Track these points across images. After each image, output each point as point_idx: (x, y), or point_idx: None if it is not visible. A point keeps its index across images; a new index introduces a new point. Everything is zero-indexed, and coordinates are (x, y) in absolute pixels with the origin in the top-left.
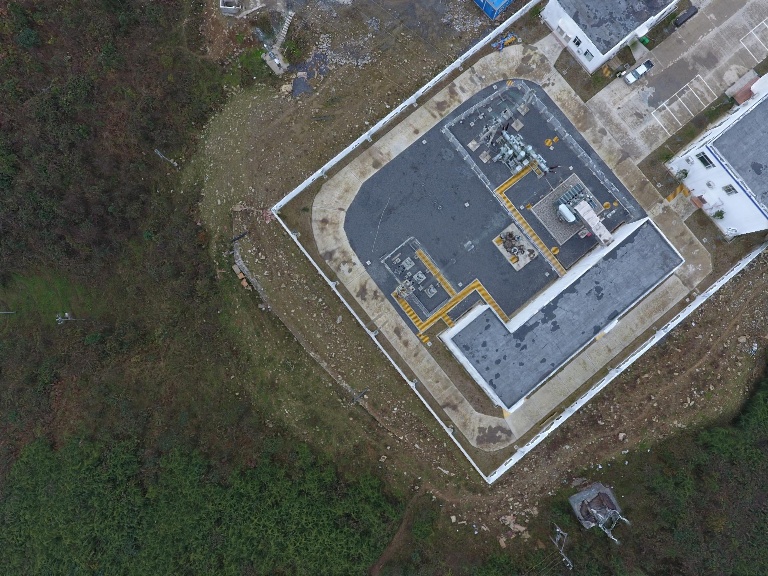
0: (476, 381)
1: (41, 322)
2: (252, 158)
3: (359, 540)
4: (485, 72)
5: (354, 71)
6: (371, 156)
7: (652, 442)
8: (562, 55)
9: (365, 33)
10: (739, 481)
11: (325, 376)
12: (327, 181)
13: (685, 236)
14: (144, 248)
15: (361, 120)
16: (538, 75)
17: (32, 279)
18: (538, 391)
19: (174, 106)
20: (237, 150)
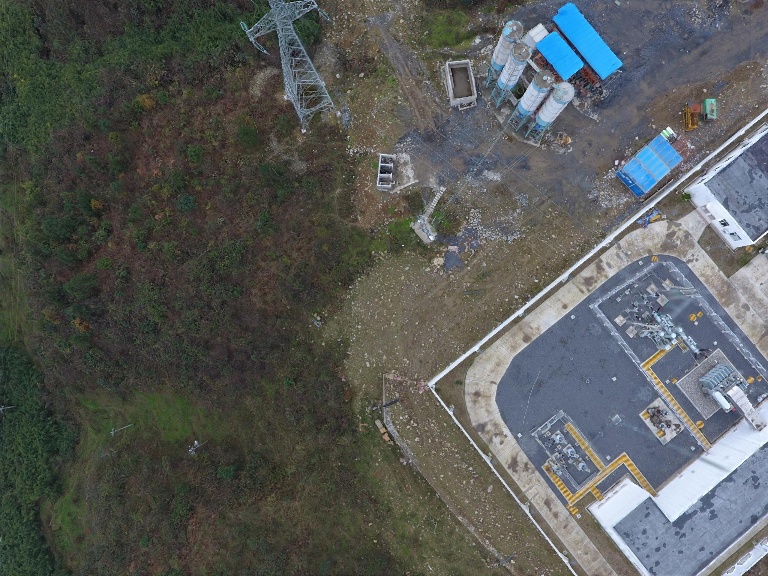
0: (627, 556)
1: (161, 437)
2: (407, 331)
3: None
4: (631, 248)
5: (504, 246)
6: (521, 330)
7: None
8: (705, 231)
9: (514, 209)
10: None
11: (469, 536)
12: (479, 355)
13: None
14: (276, 386)
15: (511, 294)
16: (682, 251)
17: (152, 395)
18: None
19: (322, 267)
20: (392, 322)
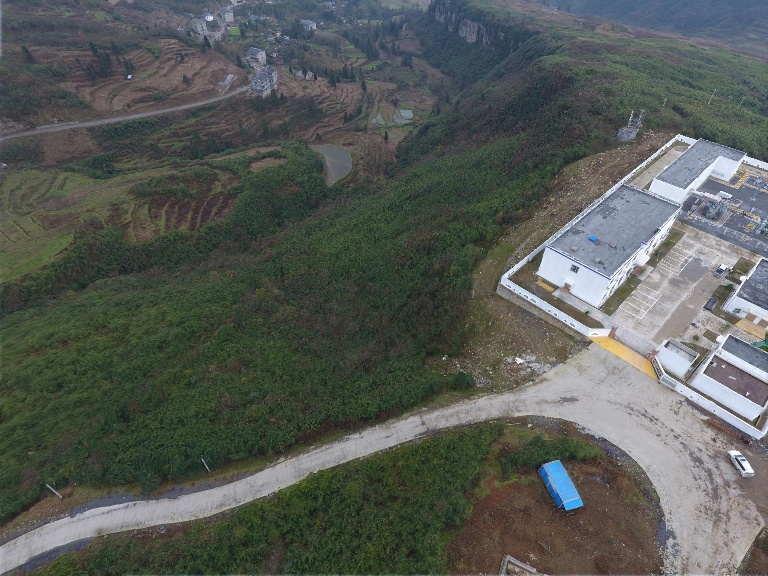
0: None
1: None
2: None
3: None
4: None
5: None
6: None
7: None
8: None
9: None
10: None
11: None
12: None
13: None
14: None
15: None
16: None
17: None
18: None
19: None
20: None
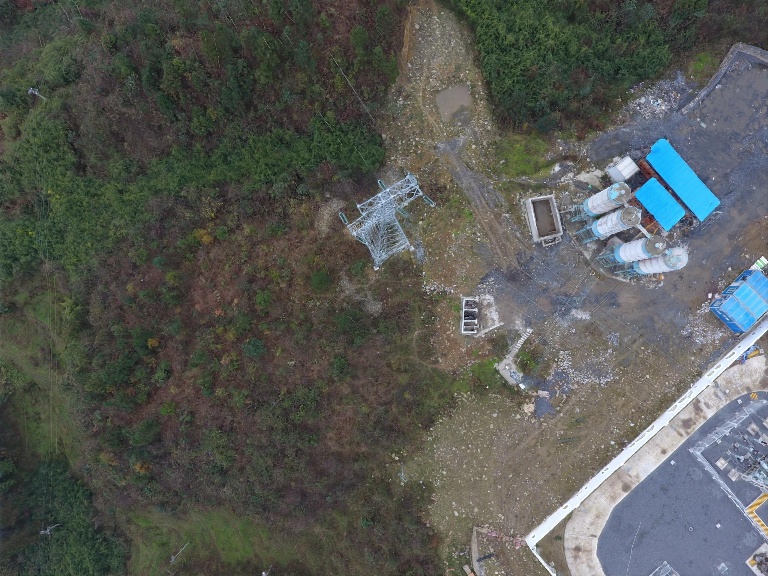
0: None
1: (220, 558)
2: (500, 485)
3: None
4: (729, 386)
5: (597, 390)
6: (620, 479)
7: None
8: None
9: (605, 349)
10: None
11: None
12: None
13: None
14: (348, 518)
15: (606, 440)
16: None
17: (209, 514)
18: None
19: None
20: (484, 476)
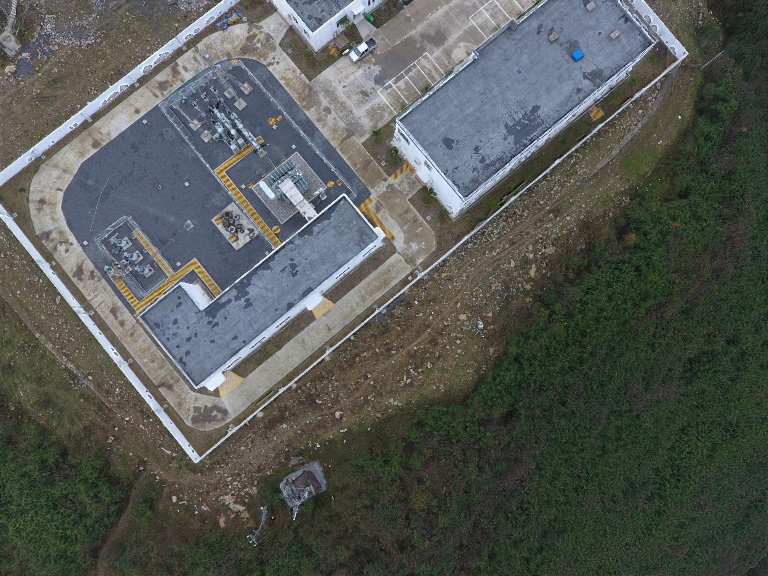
0: None
1: None
2: None
3: (77, 521)
4: (209, 51)
5: (77, 51)
6: (91, 136)
7: (372, 420)
8: (288, 34)
9: (90, 13)
10: (458, 459)
11: None
12: (45, 161)
13: (409, 214)
14: None
15: (83, 100)
16: (263, 54)
17: None
18: (255, 370)
19: None
20: None
